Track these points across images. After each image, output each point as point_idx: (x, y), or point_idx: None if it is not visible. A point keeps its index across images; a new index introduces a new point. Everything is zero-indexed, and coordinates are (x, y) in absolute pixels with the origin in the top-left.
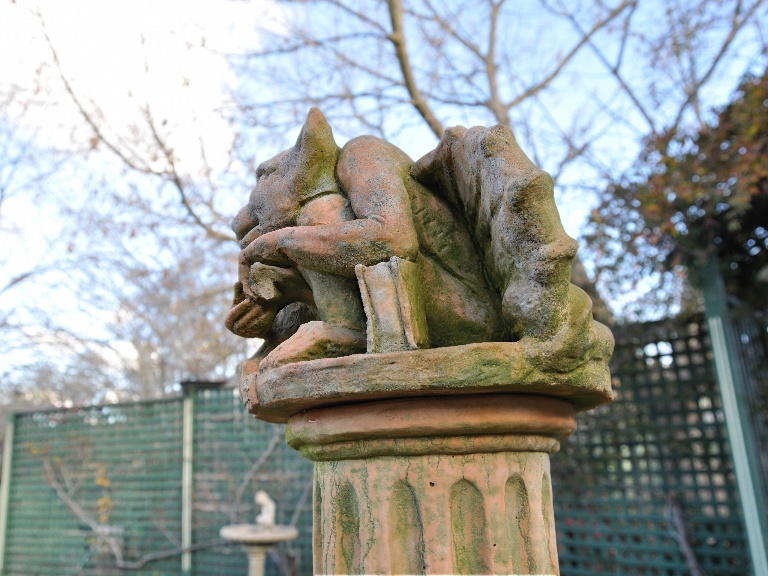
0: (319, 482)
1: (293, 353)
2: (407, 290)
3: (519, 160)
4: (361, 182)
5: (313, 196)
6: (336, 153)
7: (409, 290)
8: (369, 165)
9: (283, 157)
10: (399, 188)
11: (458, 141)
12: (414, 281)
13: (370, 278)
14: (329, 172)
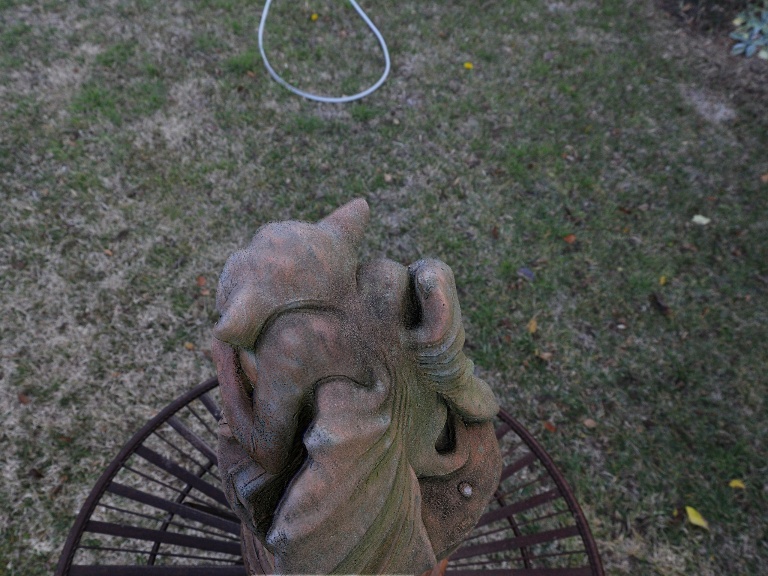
0: None
1: (224, 435)
2: (256, 502)
3: (288, 567)
4: (256, 395)
5: (242, 347)
6: (257, 331)
7: (262, 496)
8: (265, 385)
9: (231, 281)
10: (279, 423)
11: (309, 456)
12: (278, 481)
13: (233, 482)
14: (250, 345)
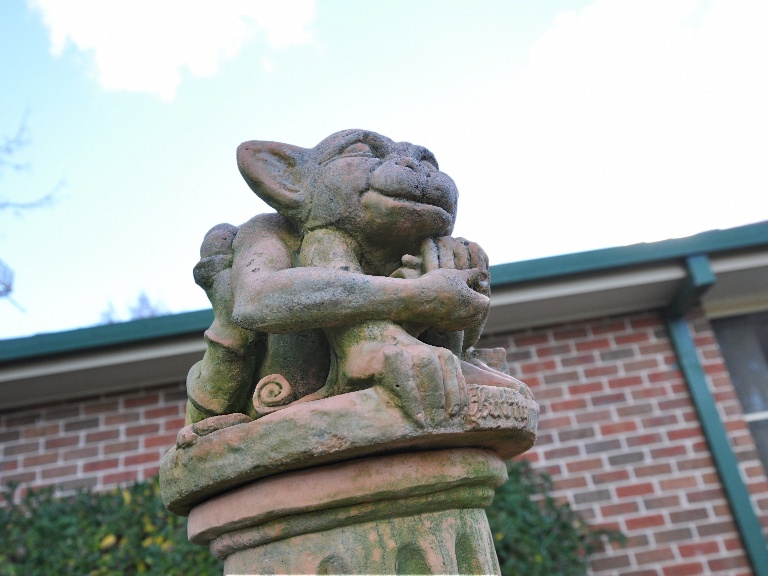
0: (470, 533)
1: None
2: None
3: None
4: None
5: None
6: None
7: None
8: None
9: None
10: None
11: None
12: None
13: None
14: None
